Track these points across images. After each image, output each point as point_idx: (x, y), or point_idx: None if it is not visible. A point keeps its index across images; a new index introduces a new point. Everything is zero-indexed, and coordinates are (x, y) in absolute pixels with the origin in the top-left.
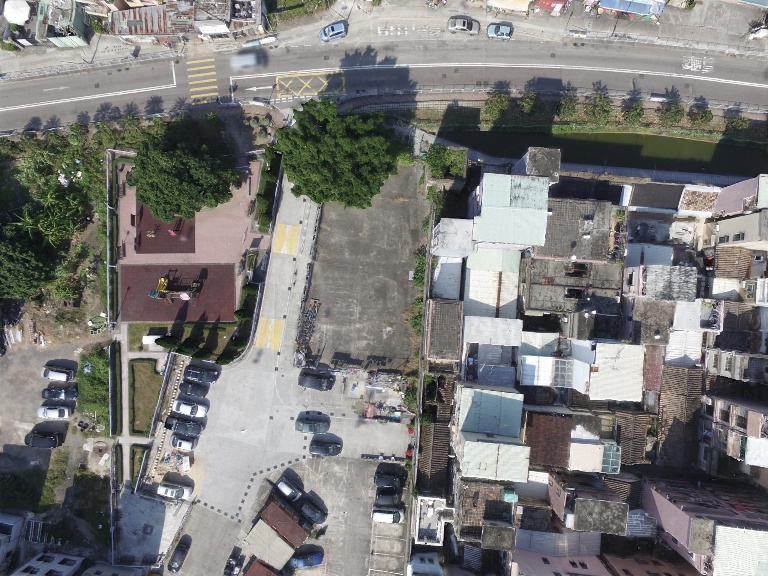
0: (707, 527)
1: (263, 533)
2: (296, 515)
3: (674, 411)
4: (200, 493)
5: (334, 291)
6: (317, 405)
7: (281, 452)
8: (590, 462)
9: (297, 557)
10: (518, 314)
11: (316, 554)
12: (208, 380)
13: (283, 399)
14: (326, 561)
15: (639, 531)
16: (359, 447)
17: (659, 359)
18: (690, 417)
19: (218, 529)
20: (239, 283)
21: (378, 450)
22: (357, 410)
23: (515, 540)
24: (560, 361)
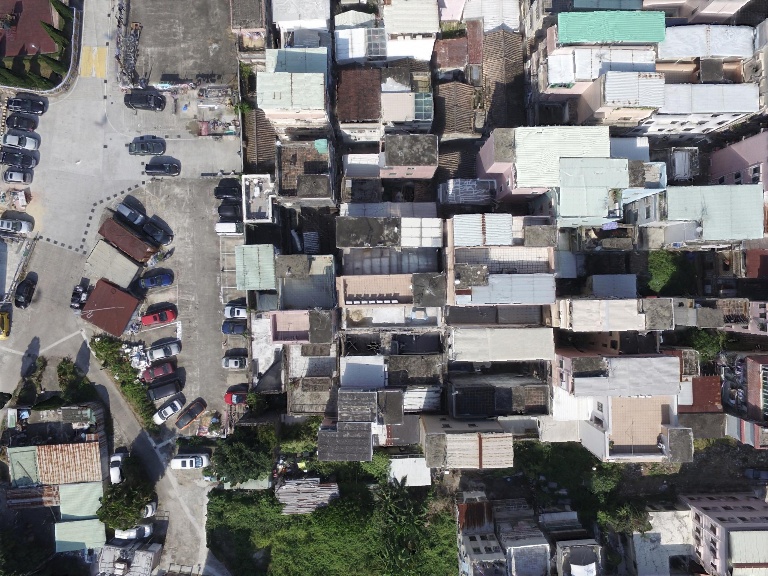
0: (509, 135)
1: (104, 252)
2: (138, 235)
3: (496, 76)
4: (41, 229)
5: (154, 13)
6: (150, 129)
7: (119, 180)
8: (402, 110)
9: (144, 278)
10: (336, 6)
11: (164, 274)
12: (33, 109)
13: (115, 127)
14: (177, 283)
15: (473, 198)
16: (198, 167)
17: (480, 34)
18: (511, 80)
19: (64, 263)
20: (56, 13)
21: (217, 168)
22: (192, 130)
23: (330, 186)
24: (372, 30)
